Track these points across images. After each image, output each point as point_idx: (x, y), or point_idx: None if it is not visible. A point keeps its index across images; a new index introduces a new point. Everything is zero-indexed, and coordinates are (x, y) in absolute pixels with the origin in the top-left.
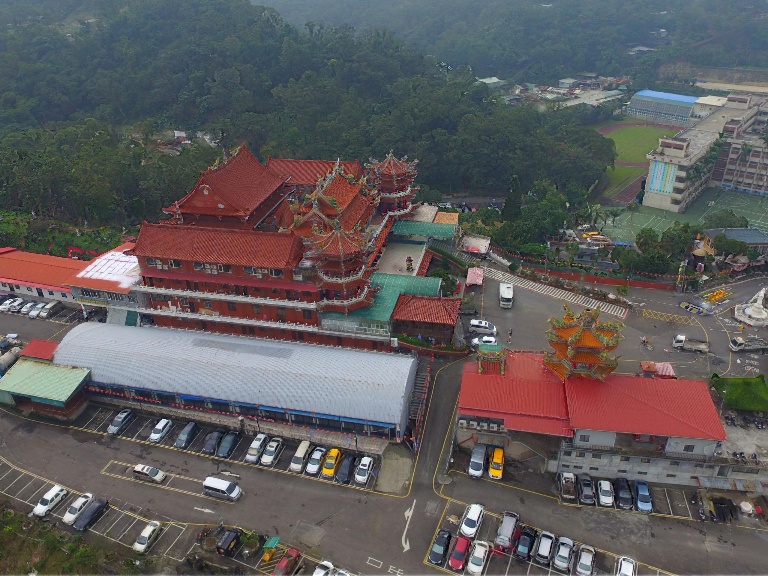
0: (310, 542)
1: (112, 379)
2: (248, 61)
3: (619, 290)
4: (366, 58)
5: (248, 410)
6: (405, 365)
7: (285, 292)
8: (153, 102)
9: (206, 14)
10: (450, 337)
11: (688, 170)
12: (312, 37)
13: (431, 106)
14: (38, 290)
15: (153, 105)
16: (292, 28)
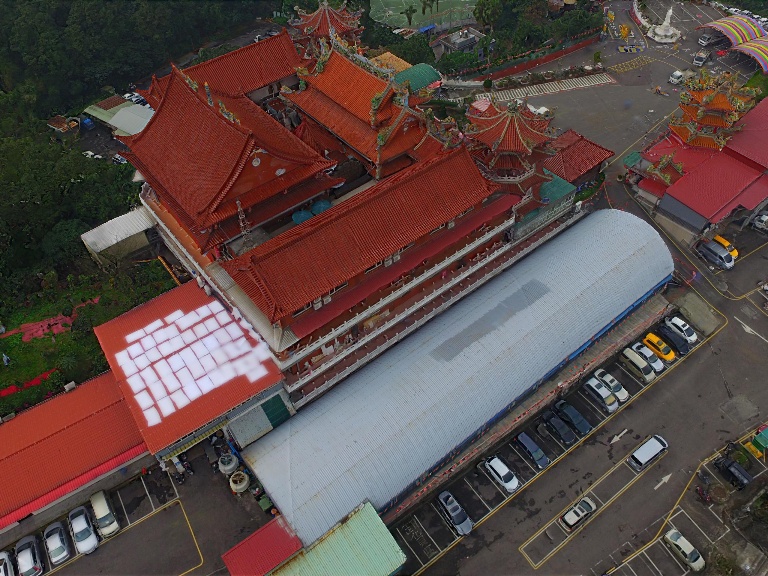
0: (752, 412)
1: (404, 483)
2: None
3: (596, 58)
4: None
5: None
6: (629, 217)
7: None
8: None
9: None
10: None
11: None
12: None
13: None
14: None
15: None
16: None
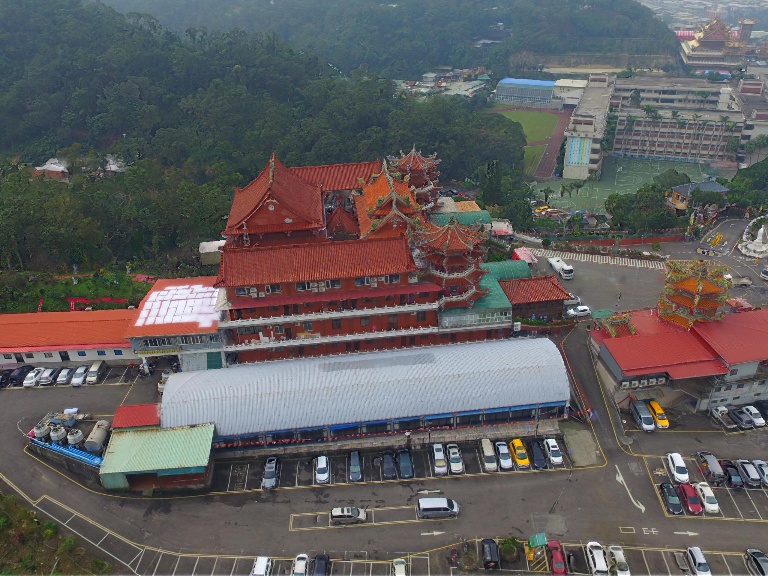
0: (558, 530)
1: (245, 428)
2: (135, 73)
3: (654, 247)
4: (268, 62)
5: (409, 424)
6: (549, 344)
7: (399, 298)
8: (25, 128)
9: (71, 24)
10: (561, 312)
11: (601, 142)
12: (195, 44)
13: (358, 105)
14: (61, 354)
15: (25, 131)
16: (174, 35)
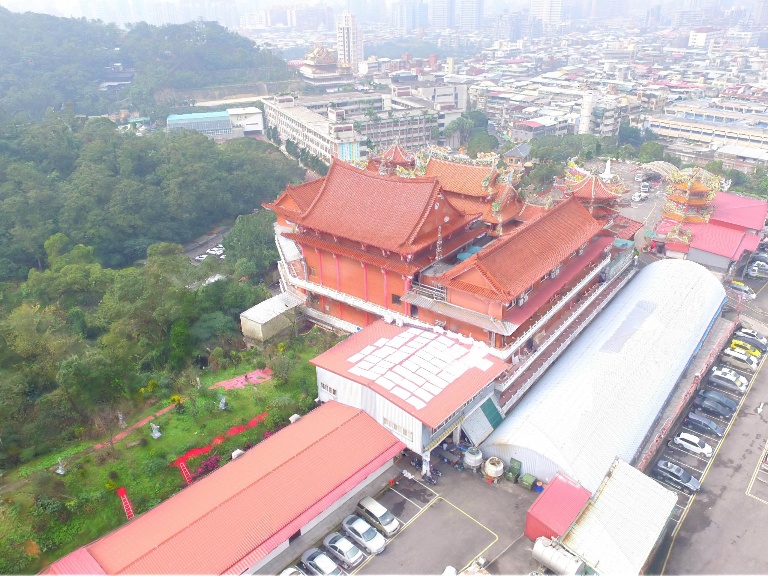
0: None
1: (635, 446)
2: None
3: None
4: None
5: None
6: (679, 261)
7: None
8: None
9: None
10: None
11: (367, 144)
12: None
13: (127, 144)
14: None
15: None
16: None
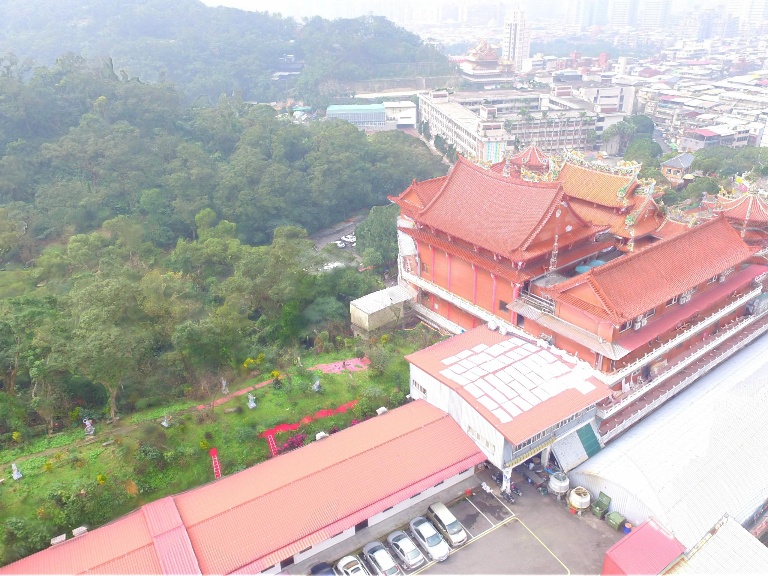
0: None
1: (753, 505)
2: None
3: None
4: None
5: None
6: None
7: None
8: None
9: None
10: None
11: (515, 144)
12: None
13: (282, 131)
14: None
15: None
16: None
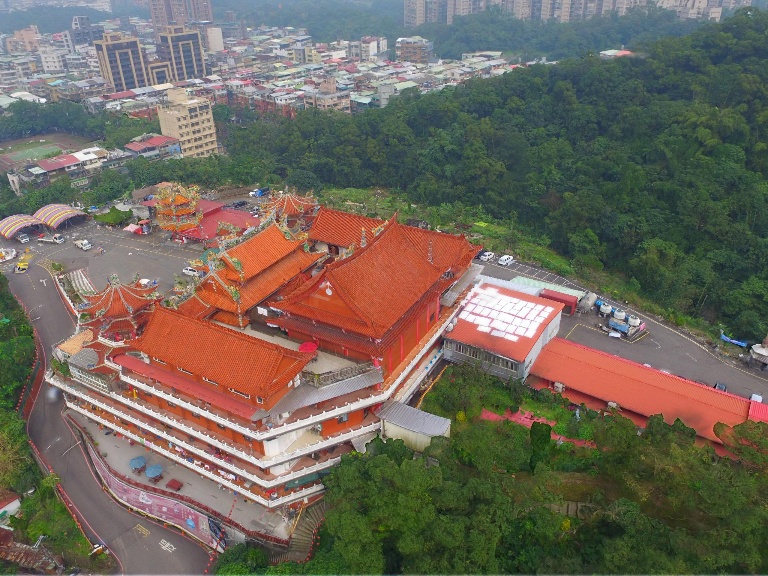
0: None
1: None
2: None
3: (60, 267)
4: None
5: None
6: None
7: None
8: None
9: None
10: None
11: None
12: None
13: None
14: None
15: None
16: None
